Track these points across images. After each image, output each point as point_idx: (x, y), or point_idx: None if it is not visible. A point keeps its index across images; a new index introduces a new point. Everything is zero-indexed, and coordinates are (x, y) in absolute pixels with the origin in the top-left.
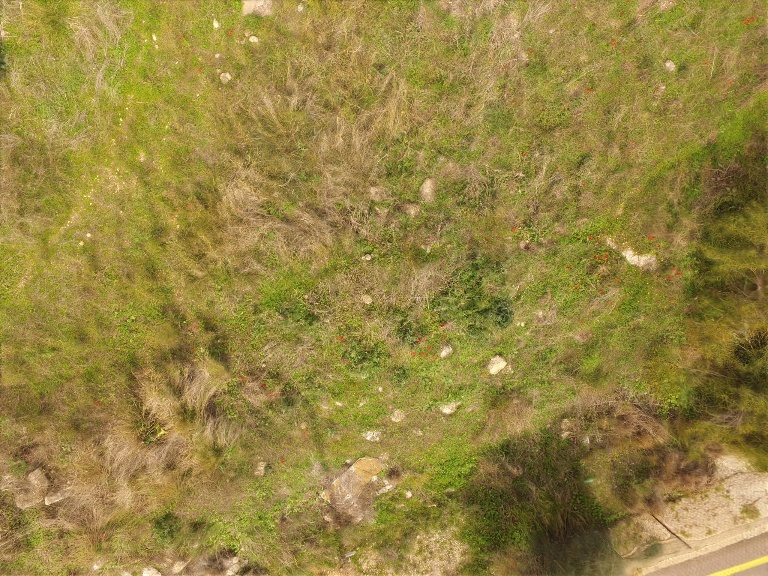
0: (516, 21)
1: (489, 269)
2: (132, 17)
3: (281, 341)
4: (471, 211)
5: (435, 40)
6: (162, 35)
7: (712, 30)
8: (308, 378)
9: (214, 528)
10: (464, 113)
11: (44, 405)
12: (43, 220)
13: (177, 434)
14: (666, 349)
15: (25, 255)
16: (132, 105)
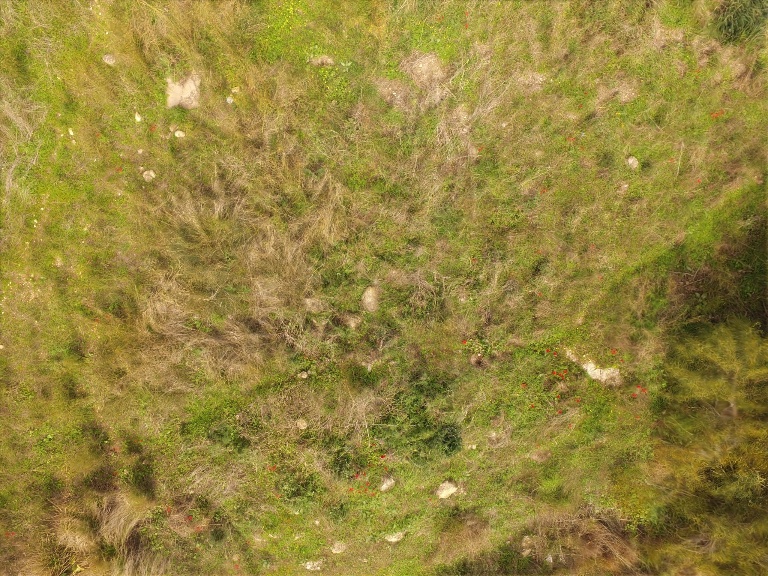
0: (466, 114)
1: (435, 390)
2: (46, 111)
3: (210, 465)
4: (417, 322)
5: (377, 136)
6: (79, 129)
7: (678, 123)
8: (239, 508)
9: None
10: (407, 218)
11: None
12: None
13: (94, 572)
14: (632, 467)
15: None
16: (47, 205)
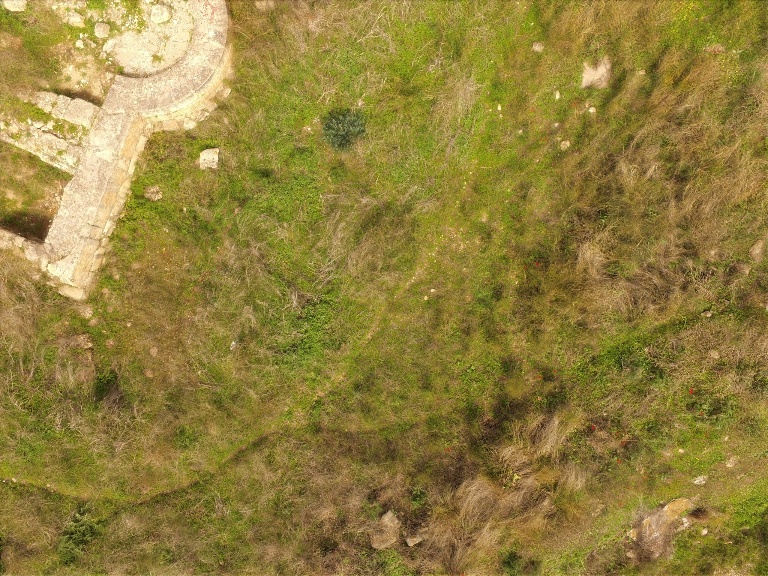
0: None
1: None
2: (482, 89)
3: (622, 391)
4: None
5: None
6: (507, 105)
7: None
8: (651, 427)
9: (542, 566)
10: None
11: (394, 450)
12: (397, 277)
13: (532, 479)
14: None
15: (374, 309)
16: (476, 170)
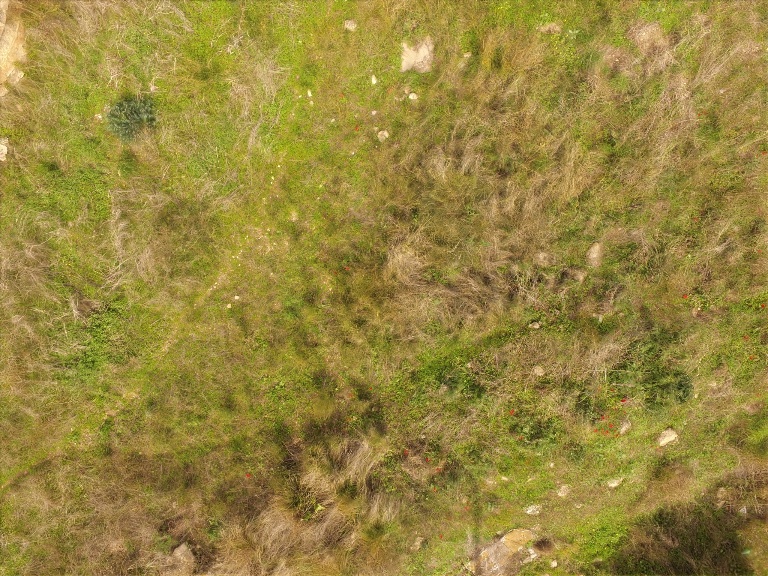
0: (686, 80)
1: (666, 340)
2: (288, 73)
3: (442, 411)
4: (641, 277)
5: None
6: (318, 91)
7: None
8: (472, 451)
9: None
10: (639, 177)
11: (190, 476)
12: (193, 283)
13: (336, 510)
14: None
15: (170, 318)
16: (284, 163)
